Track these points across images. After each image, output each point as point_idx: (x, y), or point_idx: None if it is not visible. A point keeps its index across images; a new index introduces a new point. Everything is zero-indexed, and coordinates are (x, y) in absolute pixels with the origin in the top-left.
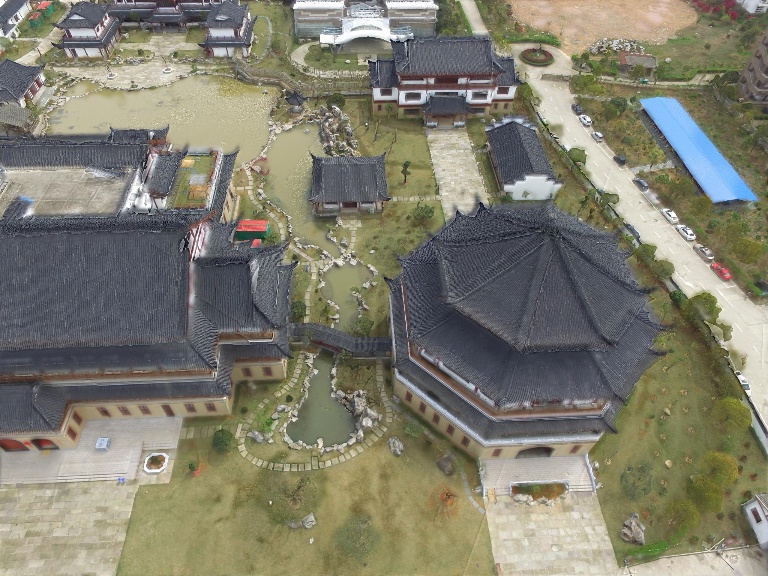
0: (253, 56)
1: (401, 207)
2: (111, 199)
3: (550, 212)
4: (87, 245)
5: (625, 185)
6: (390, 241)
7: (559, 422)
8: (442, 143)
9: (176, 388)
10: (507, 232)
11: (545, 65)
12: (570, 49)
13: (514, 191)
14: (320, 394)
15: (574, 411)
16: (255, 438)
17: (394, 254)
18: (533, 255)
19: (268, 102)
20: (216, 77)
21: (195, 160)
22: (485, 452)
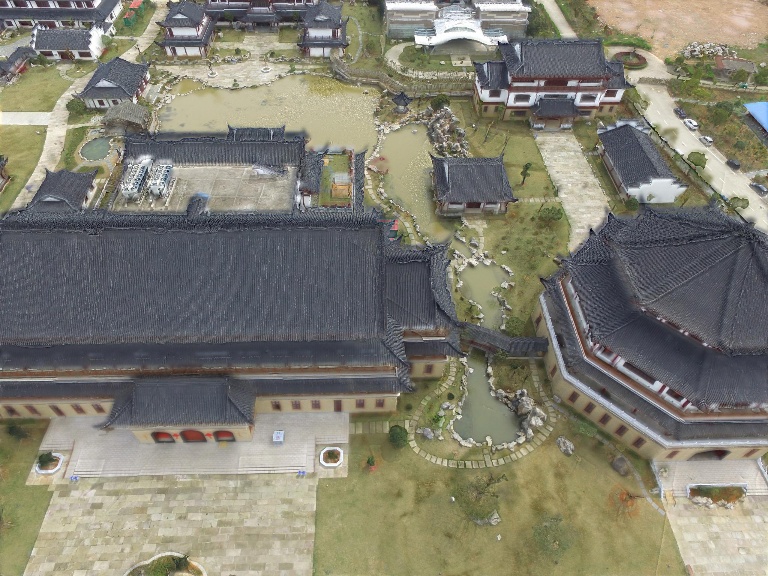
0: (348, 56)
1: (523, 208)
2: (278, 196)
3: (719, 216)
4: (287, 241)
5: (743, 190)
6: (519, 242)
7: (746, 425)
8: (551, 145)
9: (359, 383)
10: (689, 235)
11: (639, 68)
12: (661, 53)
13: (637, 194)
14: (479, 392)
15: (763, 415)
16: (426, 435)
17: (526, 255)
18: (730, 258)
19: (370, 102)
20: (314, 77)
21: (329, 159)
22: (662, 454)
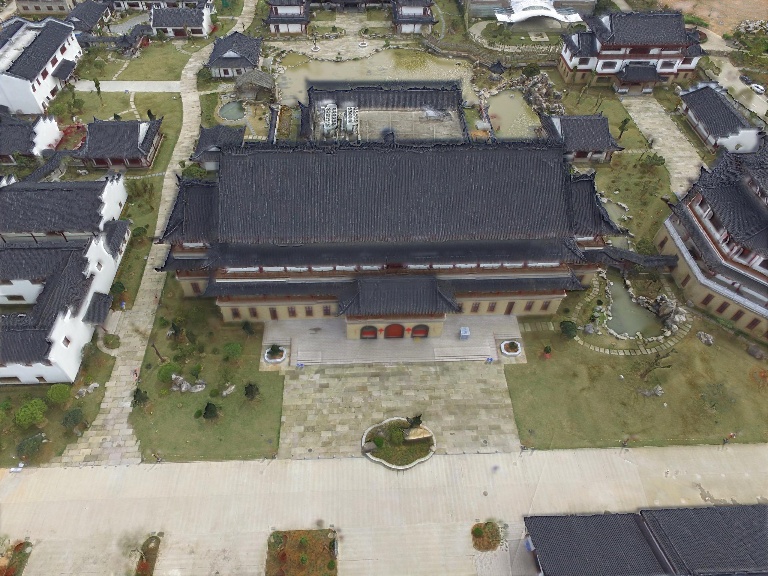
0: (436, 33)
1: (624, 158)
2: (449, 133)
3: None
4: (489, 159)
5: None
6: (628, 185)
7: None
8: (637, 107)
9: (539, 283)
10: None
11: None
12: (718, 29)
13: (725, 144)
14: (622, 300)
15: None
16: (588, 330)
17: (637, 194)
18: None
19: (464, 72)
20: (408, 51)
21: None
22: None
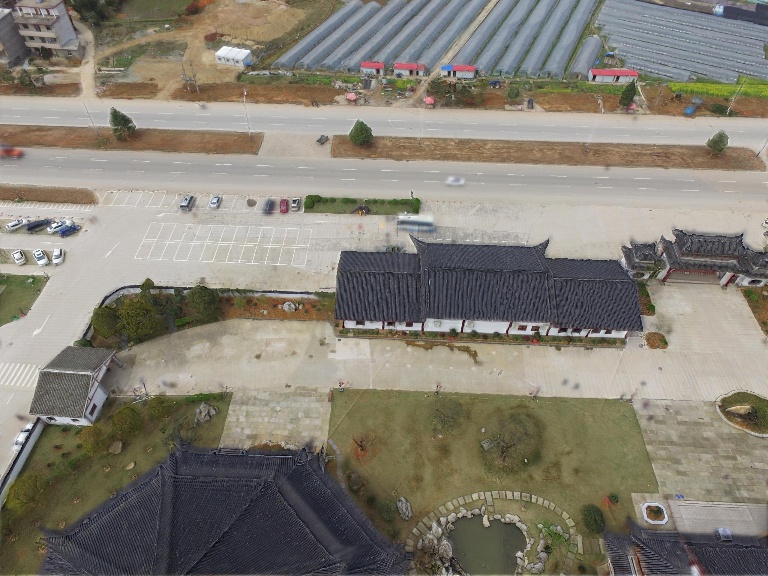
0: None
1: None
2: None
3: None
4: None
5: None
6: None
7: None
8: None
9: None
10: None
11: None
12: None
13: None
14: None
15: None
16: None
17: None
18: None
19: None
20: None
21: None
22: None
